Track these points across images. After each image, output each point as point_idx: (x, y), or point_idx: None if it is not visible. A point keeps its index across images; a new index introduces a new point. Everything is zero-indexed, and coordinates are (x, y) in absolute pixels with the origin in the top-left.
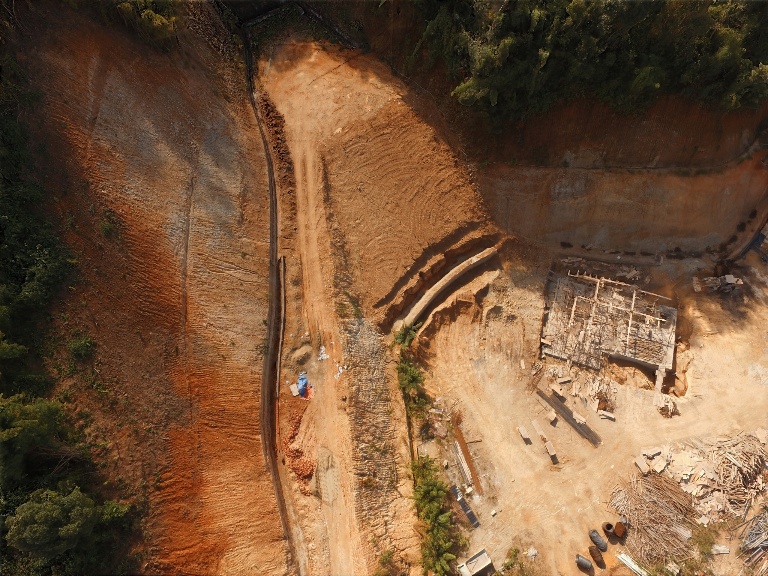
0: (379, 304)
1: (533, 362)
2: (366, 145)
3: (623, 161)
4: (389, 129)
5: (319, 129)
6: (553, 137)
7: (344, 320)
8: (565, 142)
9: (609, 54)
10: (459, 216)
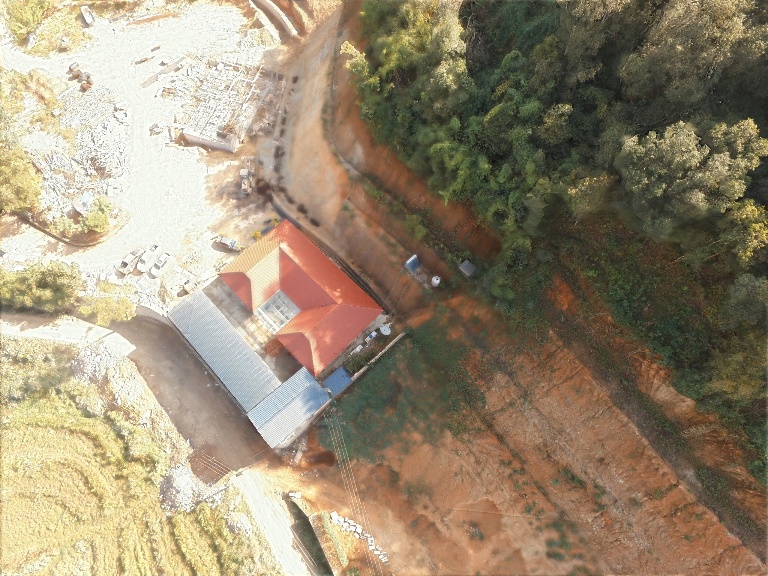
0: None
1: None
2: None
3: None
4: None
5: None
6: None
7: None
8: None
9: None
10: (317, 0)
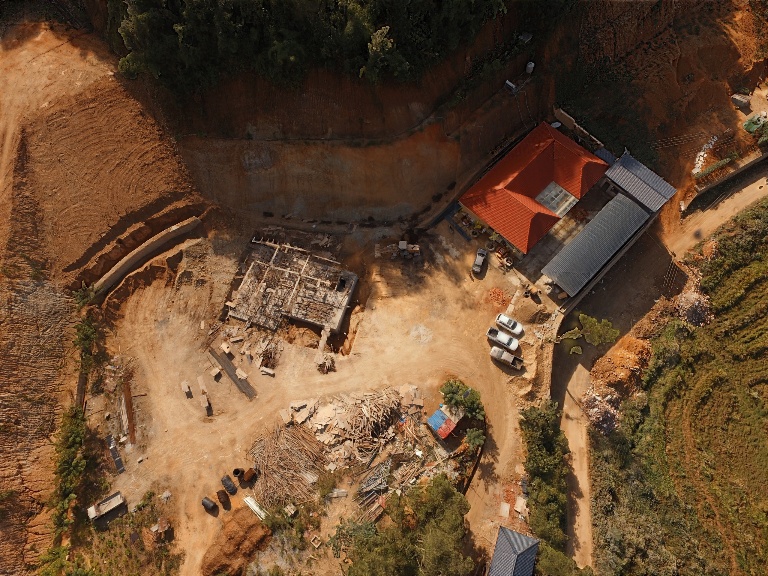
0: (70, 268)
1: (211, 323)
2: (69, 119)
3: (301, 133)
4: (95, 104)
5: (27, 103)
6: (231, 110)
7: (12, 280)
8: (243, 115)
9: (250, 29)
10: (161, 186)
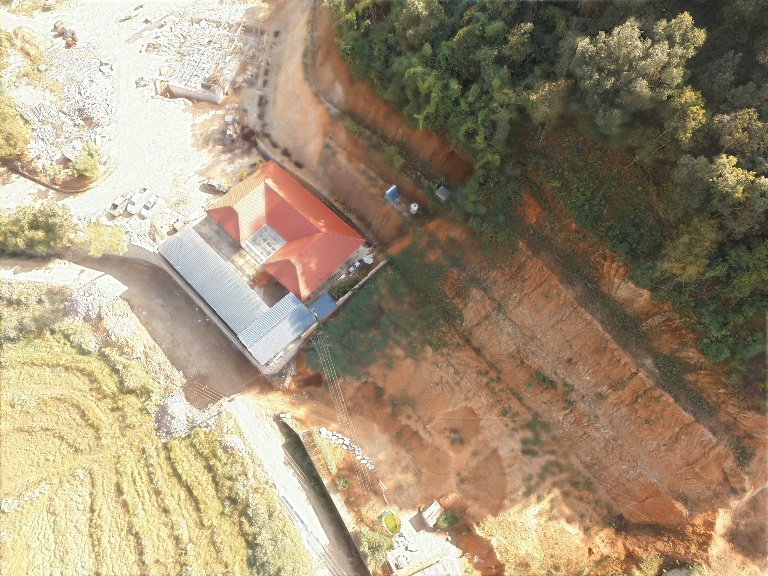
0: None
1: None
2: None
3: None
4: None
5: None
6: None
7: None
8: None
9: None
10: None
